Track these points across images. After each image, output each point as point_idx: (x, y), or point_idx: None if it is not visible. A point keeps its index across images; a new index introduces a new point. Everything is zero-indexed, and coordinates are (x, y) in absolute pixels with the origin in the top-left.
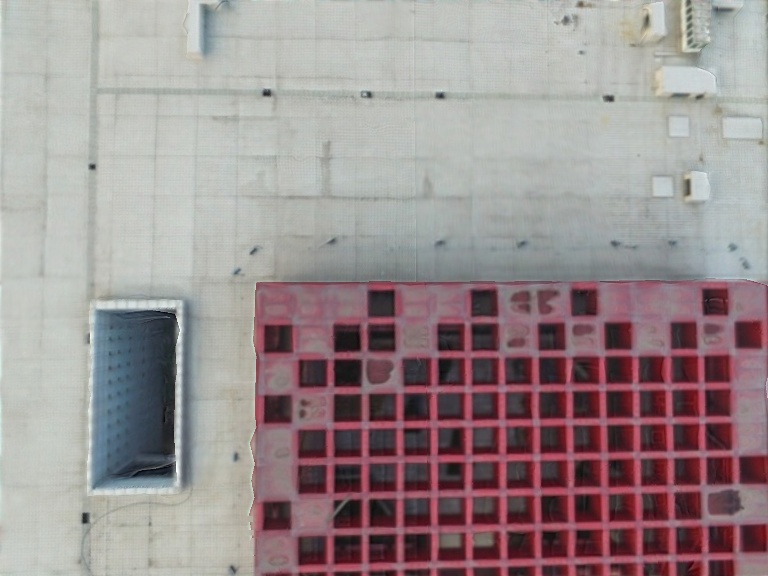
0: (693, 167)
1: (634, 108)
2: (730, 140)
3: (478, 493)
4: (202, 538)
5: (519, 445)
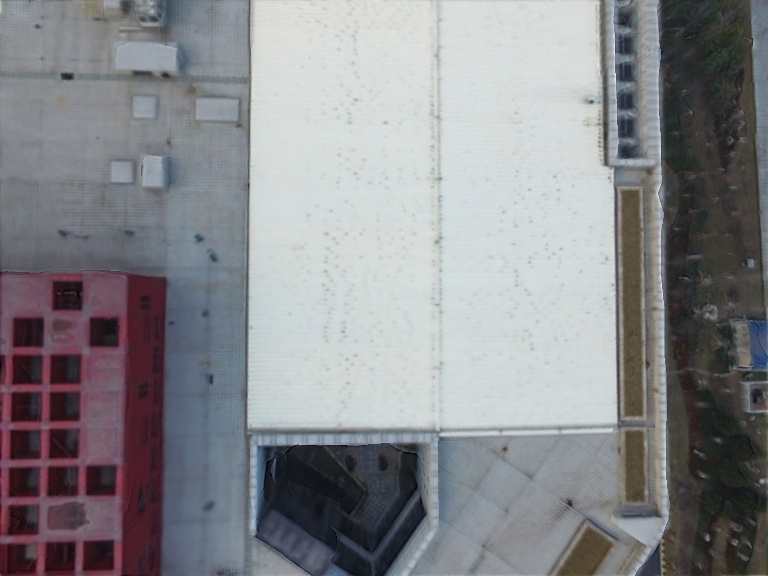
0: (159, 151)
1: (97, 87)
2: (203, 122)
3: None
4: None
5: None
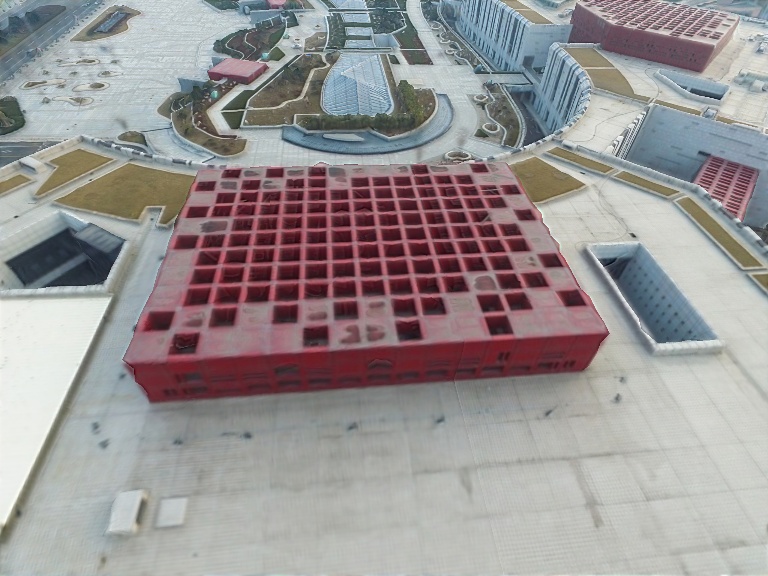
0: (119, 546)
1: None
2: None
3: (395, 227)
4: (556, 228)
5: (368, 249)
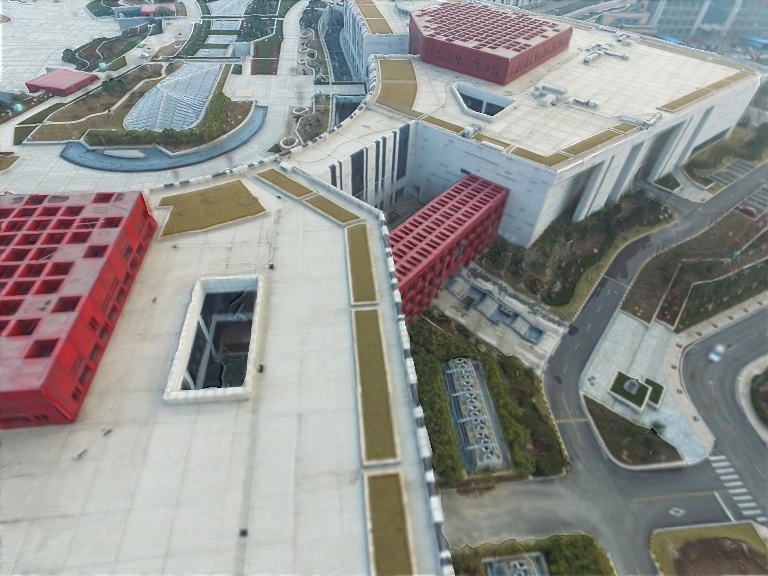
0: None
1: None
2: None
3: None
4: (193, 260)
5: None
